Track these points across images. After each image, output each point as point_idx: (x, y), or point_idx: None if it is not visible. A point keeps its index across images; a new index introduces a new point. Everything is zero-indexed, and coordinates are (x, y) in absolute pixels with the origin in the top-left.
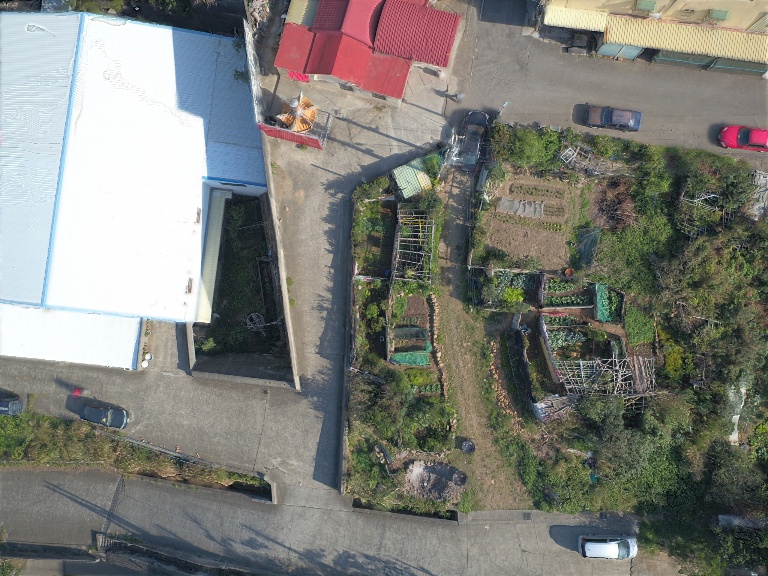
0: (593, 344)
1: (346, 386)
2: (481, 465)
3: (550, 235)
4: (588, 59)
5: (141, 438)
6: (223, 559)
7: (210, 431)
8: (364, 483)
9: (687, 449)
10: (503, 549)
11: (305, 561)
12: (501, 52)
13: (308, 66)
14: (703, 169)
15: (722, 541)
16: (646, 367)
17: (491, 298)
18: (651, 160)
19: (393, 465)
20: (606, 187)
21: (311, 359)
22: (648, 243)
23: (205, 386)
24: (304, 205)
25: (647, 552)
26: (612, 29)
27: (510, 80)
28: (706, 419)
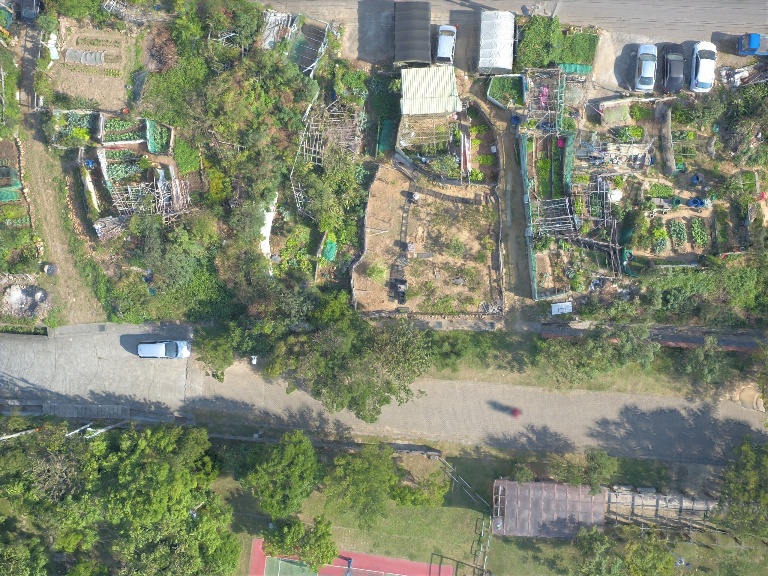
0: (147, 173)
1: None
2: (64, 286)
3: (111, 80)
4: None
5: None
6: None
7: None
8: None
9: (216, 258)
10: (83, 357)
11: None
12: None
13: None
14: (220, 10)
15: (231, 331)
16: (182, 188)
17: (53, 135)
18: (177, 5)
19: None
20: (156, 35)
21: None
22: (189, 82)
23: None
24: None
25: (198, 354)
26: None
27: None
28: (236, 232)
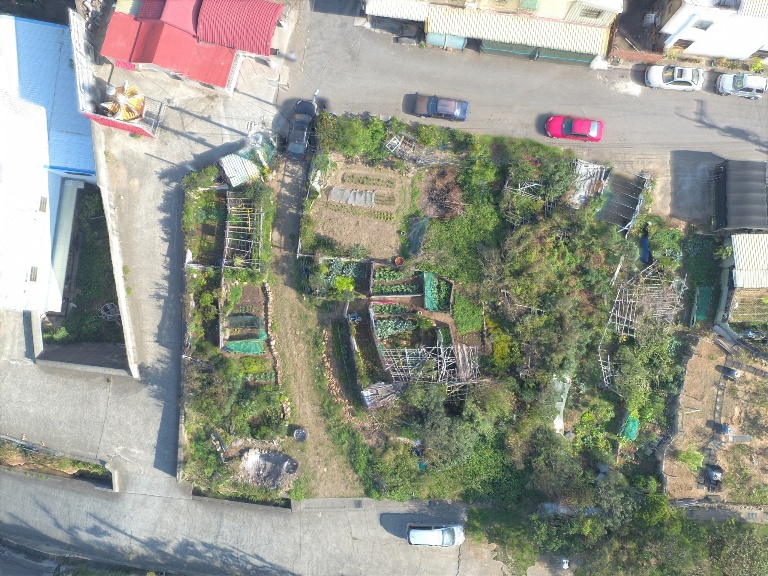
0: (422, 332)
1: (182, 374)
2: (314, 453)
3: (381, 224)
4: (418, 49)
5: None
6: (69, 547)
7: (55, 419)
8: (200, 471)
9: (509, 436)
10: (335, 537)
11: (146, 549)
12: (333, 42)
13: (133, 55)
14: (524, 158)
15: (536, 528)
16: (470, 355)
17: (318, 286)
18: (474, 149)
19: (228, 453)
20: (436, 176)
21: (150, 347)
22: (476, 232)
23: (51, 374)
24: (139, 194)
25: (474, 540)
26: (432, 19)
27: (341, 70)
28: (529, 407)
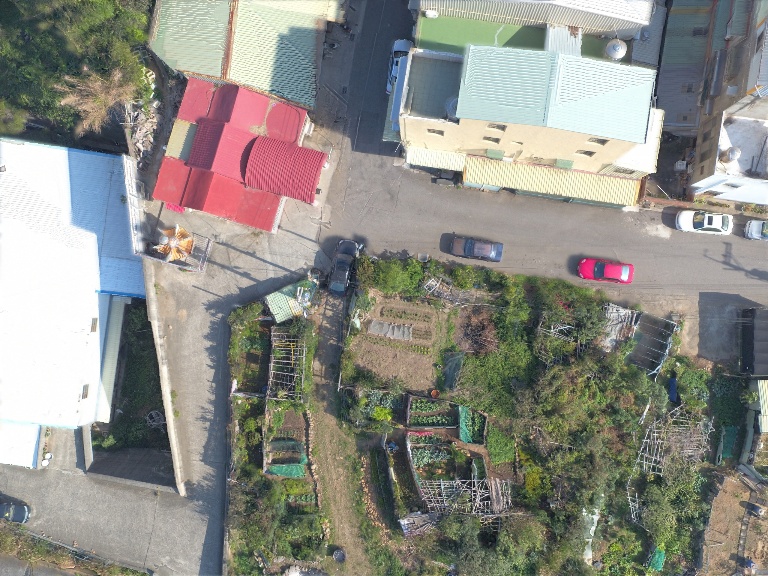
0: (456, 462)
1: (227, 494)
2: (352, 572)
3: (418, 357)
4: (456, 190)
5: (42, 532)
6: None
7: (105, 528)
8: None
9: (539, 568)
10: None
11: None
12: (373, 182)
13: (184, 199)
14: (558, 302)
15: None
16: (503, 488)
17: (358, 419)
18: (509, 292)
19: (270, 569)
20: (472, 312)
21: (196, 466)
22: (509, 368)
23: (101, 485)
24: (187, 324)
25: None
26: (471, 169)
27: (381, 209)
28: (559, 539)
